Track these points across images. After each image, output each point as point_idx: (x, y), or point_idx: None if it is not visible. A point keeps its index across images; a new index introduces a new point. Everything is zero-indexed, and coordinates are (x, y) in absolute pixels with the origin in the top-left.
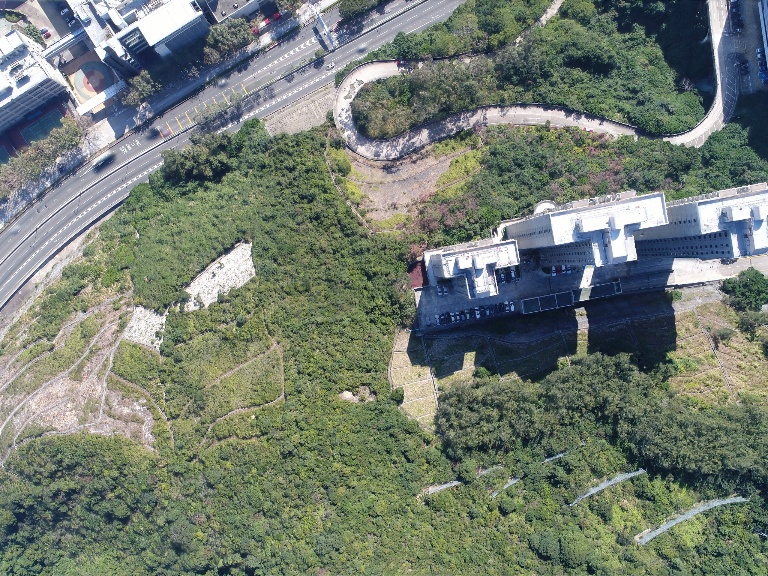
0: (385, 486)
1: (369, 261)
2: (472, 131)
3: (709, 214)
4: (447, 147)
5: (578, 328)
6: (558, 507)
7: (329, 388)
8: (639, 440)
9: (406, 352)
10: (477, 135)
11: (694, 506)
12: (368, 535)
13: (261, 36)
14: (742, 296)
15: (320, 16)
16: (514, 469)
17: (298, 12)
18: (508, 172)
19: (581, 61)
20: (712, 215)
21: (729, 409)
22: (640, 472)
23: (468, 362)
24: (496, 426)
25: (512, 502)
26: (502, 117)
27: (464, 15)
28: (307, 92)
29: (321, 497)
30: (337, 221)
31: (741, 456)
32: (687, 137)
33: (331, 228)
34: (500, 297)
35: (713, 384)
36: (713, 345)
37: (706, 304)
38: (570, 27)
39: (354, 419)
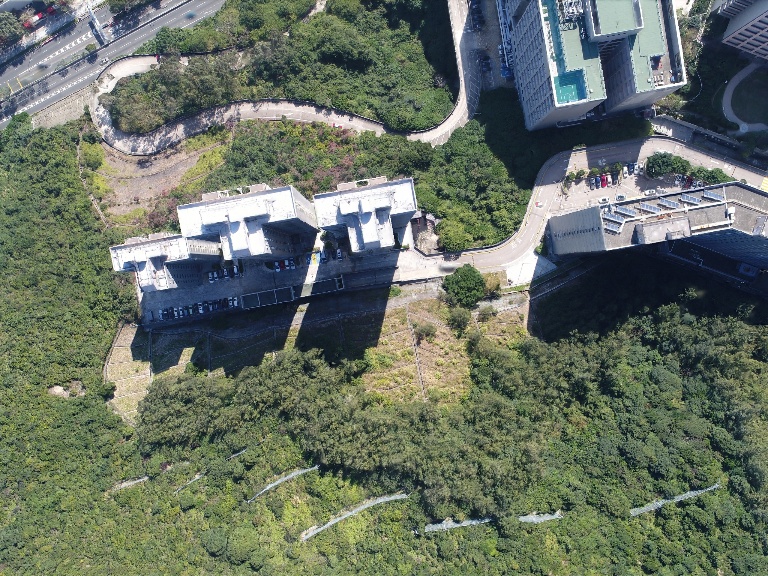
0: (78, 481)
1: (97, 255)
2: (224, 126)
3: (327, 207)
4: (198, 142)
5: (291, 324)
6: (235, 503)
7: (36, 382)
8: (308, 436)
9: (130, 347)
10: (227, 130)
11: (363, 503)
12: (51, 530)
13: (37, 30)
14: (453, 293)
15: (91, 10)
16: (198, 465)
17: (74, 6)
18: (245, 167)
19: (334, 57)
20: (330, 208)
21: (406, 405)
22: (313, 468)
23: (185, 357)
24: (180, 421)
25: (190, 498)
26: (255, 112)
27: (229, 10)
28: (81, 87)
29: (12, 492)
30: (75, 215)
31: None
32: (433, 133)
33: (70, 222)
34: (224, 292)
35: (404, 381)
36: (415, 342)
37: (420, 301)
38: (331, 23)
39: (56, 414)
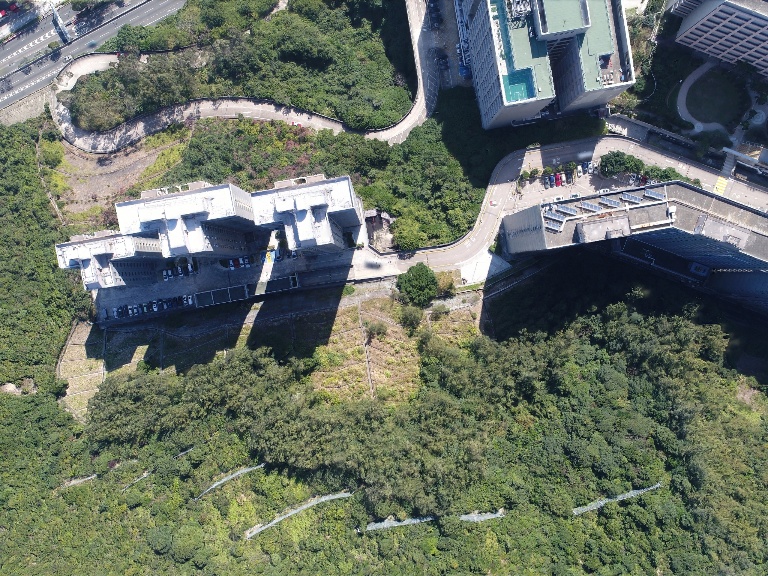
0: (27, 479)
1: (52, 253)
2: (184, 124)
3: (265, 205)
4: (158, 140)
5: (244, 322)
6: (181, 501)
7: None
8: None
9: (84, 345)
10: (187, 128)
11: (308, 501)
12: None
13: None
14: (405, 291)
15: (53, 8)
16: (145, 463)
17: (37, 4)
18: (202, 165)
19: (294, 55)
20: (268, 206)
21: (353, 404)
22: (258, 467)
23: (138, 355)
24: (127, 419)
25: (136, 496)
26: (214, 110)
27: (190, 8)
28: (44, 84)
29: None
30: (32, 213)
31: (341, 451)
32: (392, 132)
33: (27, 220)
34: (179, 290)
35: (353, 379)
36: (366, 340)
37: (373, 299)
38: (292, 21)
39: (7, 411)
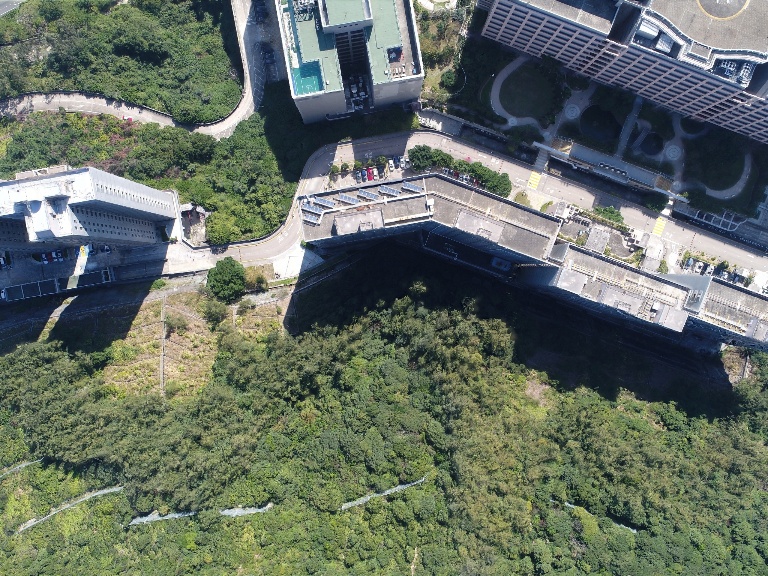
0: None
1: None
2: None
3: (6, 196)
4: None
5: (50, 316)
6: None
7: None
8: None
9: None
10: (18, 122)
11: (85, 496)
12: None
13: None
14: None
15: None
16: None
17: None
18: (24, 159)
19: (127, 49)
20: None
21: (135, 398)
22: None
23: None
24: None
25: None
26: (47, 104)
27: None
28: None
29: None
30: None
31: None
32: (221, 126)
33: None
34: None
35: (144, 373)
36: (165, 334)
37: (180, 293)
38: (130, 15)
39: None
